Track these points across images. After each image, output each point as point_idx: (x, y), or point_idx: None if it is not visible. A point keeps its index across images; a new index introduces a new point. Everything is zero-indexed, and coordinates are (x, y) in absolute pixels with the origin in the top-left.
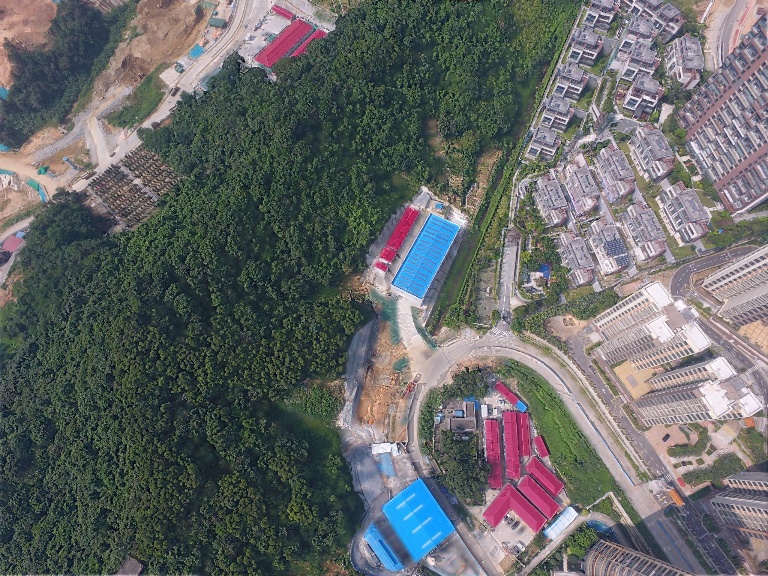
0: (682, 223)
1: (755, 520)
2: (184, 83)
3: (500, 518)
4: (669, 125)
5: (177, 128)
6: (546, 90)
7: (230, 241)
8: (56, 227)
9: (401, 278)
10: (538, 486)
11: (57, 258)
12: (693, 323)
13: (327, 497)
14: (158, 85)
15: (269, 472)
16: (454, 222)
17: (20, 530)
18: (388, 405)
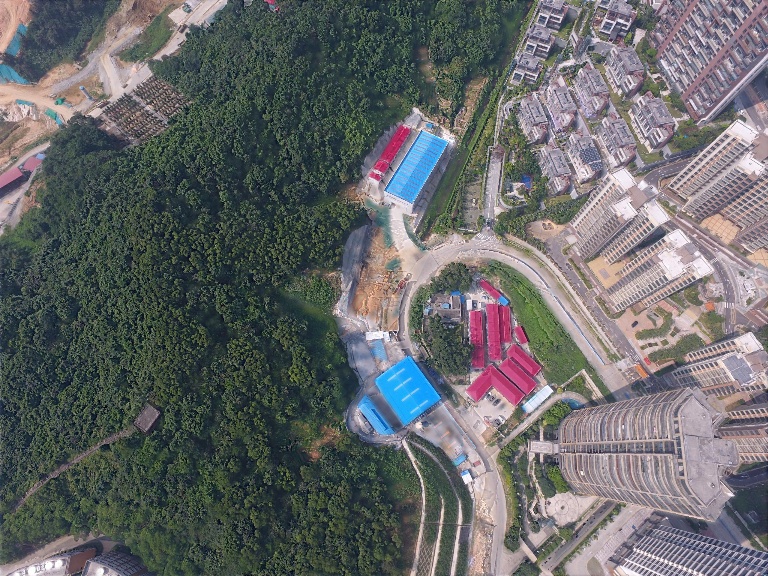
0: (650, 128)
1: (708, 376)
2: (192, 21)
3: (482, 393)
4: (641, 46)
5: (186, 57)
6: (530, 22)
7: (236, 144)
8: (75, 142)
9: (393, 186)
10: (517, 367)
11: (77, 164)
12: (654, 202)
13: (324, 366)
14: (167, 24)
15: (272, 341)
16: None
17: (47, 396)
18: (381, 299)
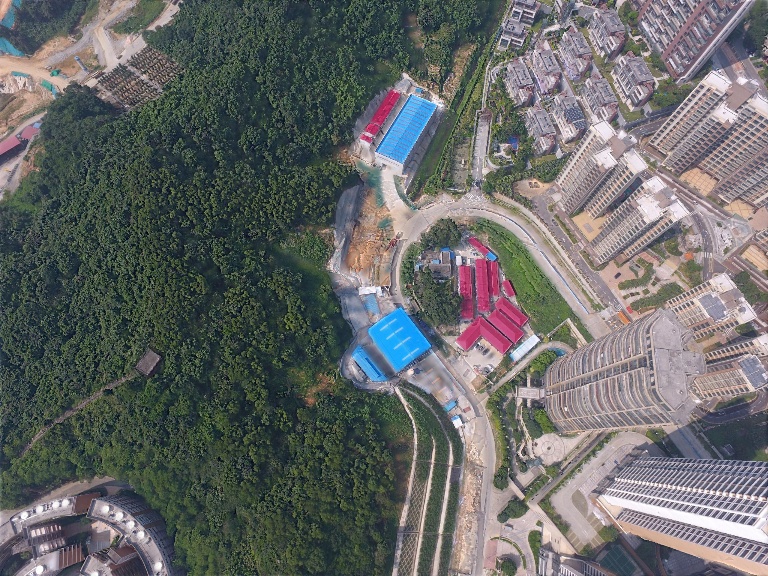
0: (631, 86)
1: (685, 317)
2: None
3: (471, 342)
4: (623, 9)
5: (179, 26)
6: None
7: (230, 105)
8: (72, 109)
9: (384, 147)
10: (505, 317)
11: (75, 128)
12: (633, 151)
13: (319, 315)
14: None
15: (268, 291)
16: None
17: (50, 348)
18: (373, 256)
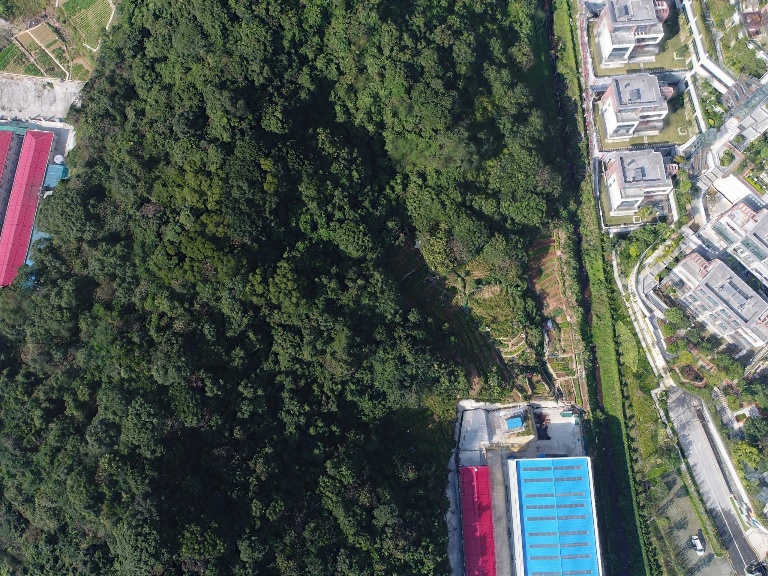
0: None
1: None
2: None
3: None
4: None
5: None
6: (584, 59)
7: None
8: None
9: None
10: None
11: None
12: None
13: None
14: None
15: None
16: (555, 431)
17: None
18: None
